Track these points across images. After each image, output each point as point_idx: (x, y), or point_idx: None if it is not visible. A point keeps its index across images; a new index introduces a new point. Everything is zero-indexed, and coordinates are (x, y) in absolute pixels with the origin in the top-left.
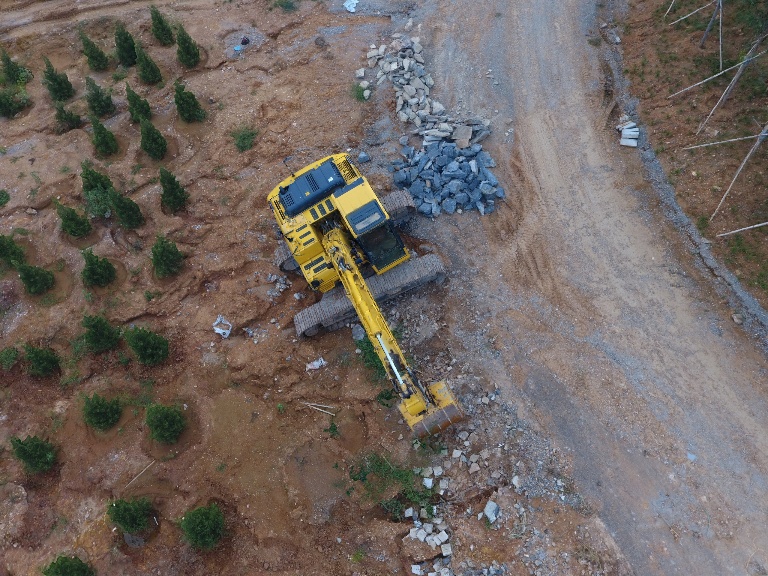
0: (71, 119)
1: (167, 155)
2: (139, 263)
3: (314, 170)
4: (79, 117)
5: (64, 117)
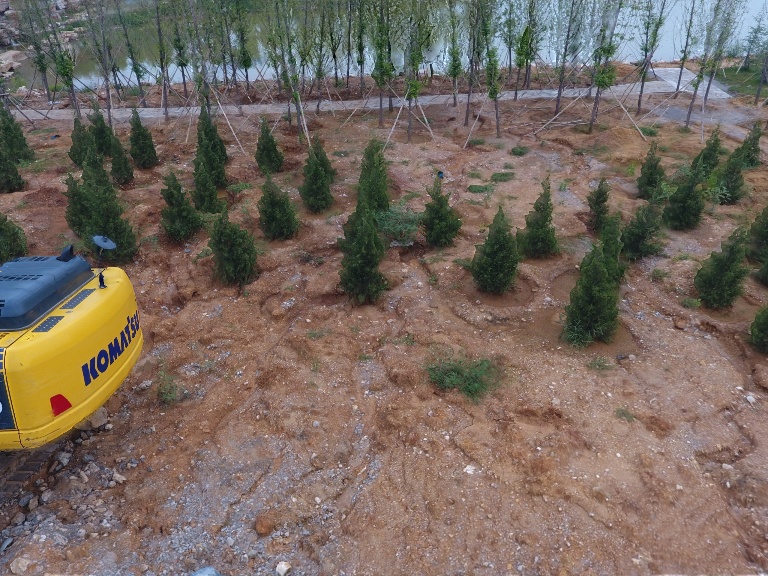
0: (600, 216)
1: (488, 296)
2: (275, 255)
3: (44, 290)
4: (608, 225)
5: (588, 198)
